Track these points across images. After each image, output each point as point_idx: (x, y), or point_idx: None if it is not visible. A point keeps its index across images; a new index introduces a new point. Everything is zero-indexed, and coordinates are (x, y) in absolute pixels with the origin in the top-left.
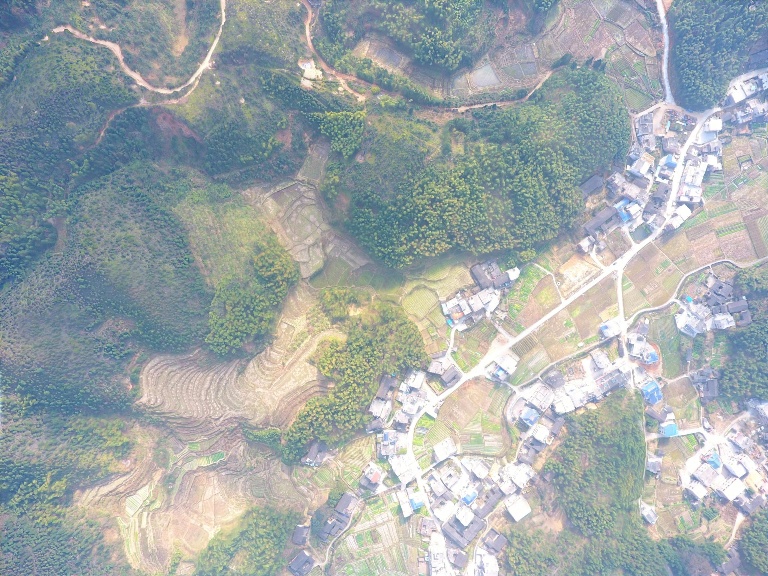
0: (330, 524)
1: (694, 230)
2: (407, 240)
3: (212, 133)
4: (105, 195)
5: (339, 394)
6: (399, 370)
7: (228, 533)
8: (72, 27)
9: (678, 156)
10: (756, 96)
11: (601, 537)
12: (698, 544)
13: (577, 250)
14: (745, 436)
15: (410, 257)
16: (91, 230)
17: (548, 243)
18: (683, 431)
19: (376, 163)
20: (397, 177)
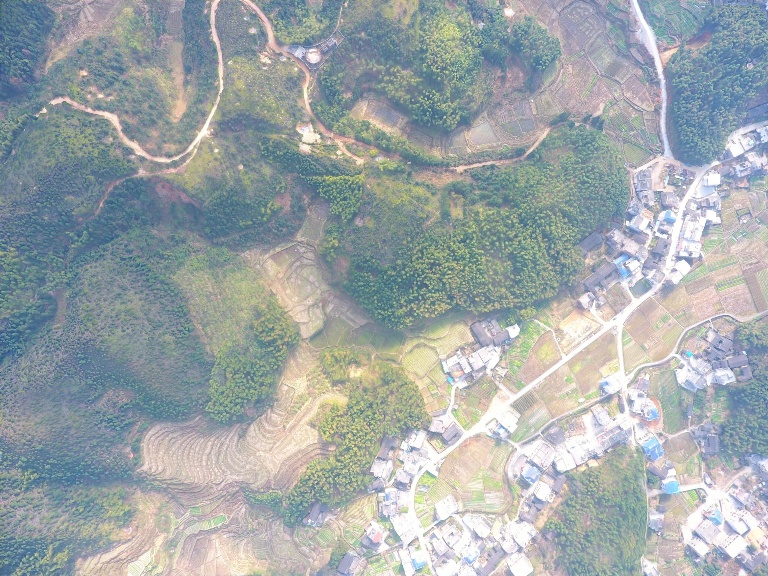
0: None
1: (694, 284)
2: (407, 302)
3: (211, 200)
4: (104, 267)
5: (340, 458)
6: (400, 430)
7: None
8: (70, 98)
9: (677, 210)
10: (754, 149)
11: None
12: None
13: (577, 306)
14: (746, 492)
15: (410, 318)
16: (91, 305)
17: (548, 299)
18: (684, 487)
19: (375, 227)
20: (396, 242)
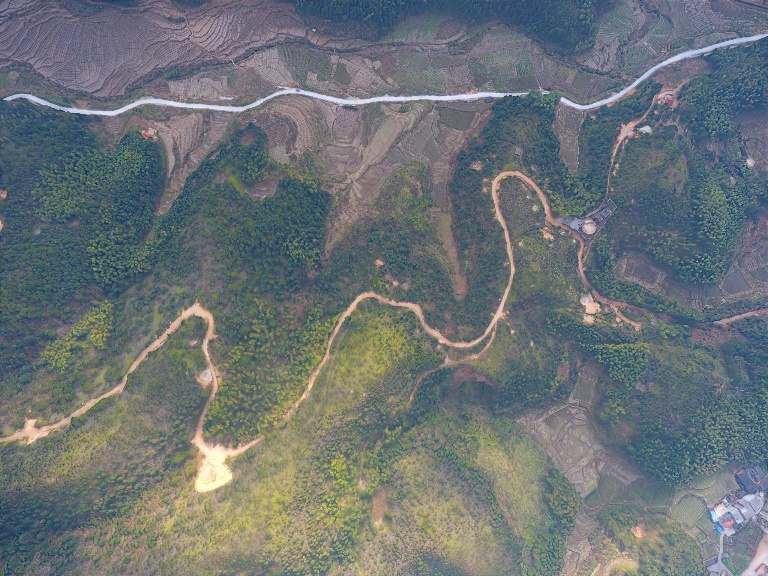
0: None
1: None
2: None
3: (508, 381)
4: (423, 462)
5: None
6: None
7: None
8: (375, 292)
9: None
10: None
11: None
12: None
13: None
14: None
15: (691, 477)
16: (424, 508)
17: None
18: None
19: (664, 395)
20: (689, 410)
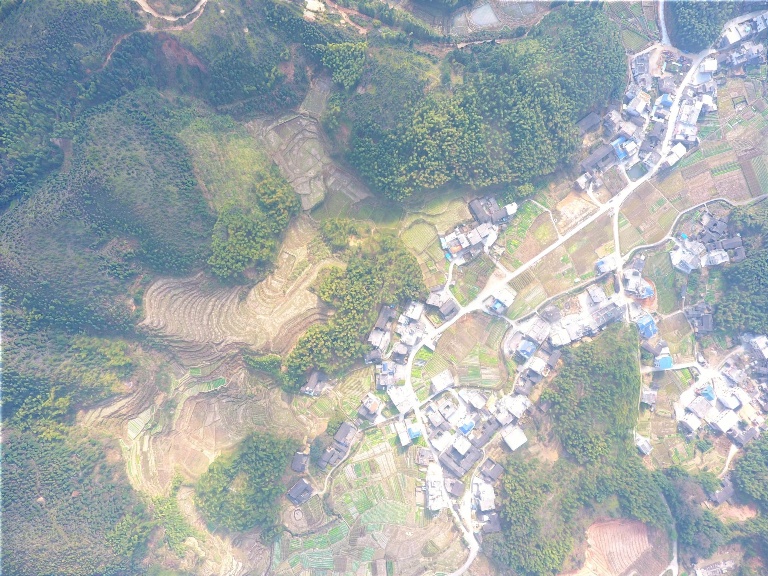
0: (329, 452)
1: (689, 169)
2: (407, 171)
3: (216, 60)
4: (111, 116)
5: (339, 320)
6: (398, 301)
7: (228, 456)
8: None
9: (674, 96)
10: (751, 39)
11: (596, 463)
12: (692, 474)
13: (574, 187)
14: (739, 369)
15: (409, 188)
16: (97, 147)
17: (545, 180)
18: (678, 365)
19: (377, 93)
20: (397, 106)
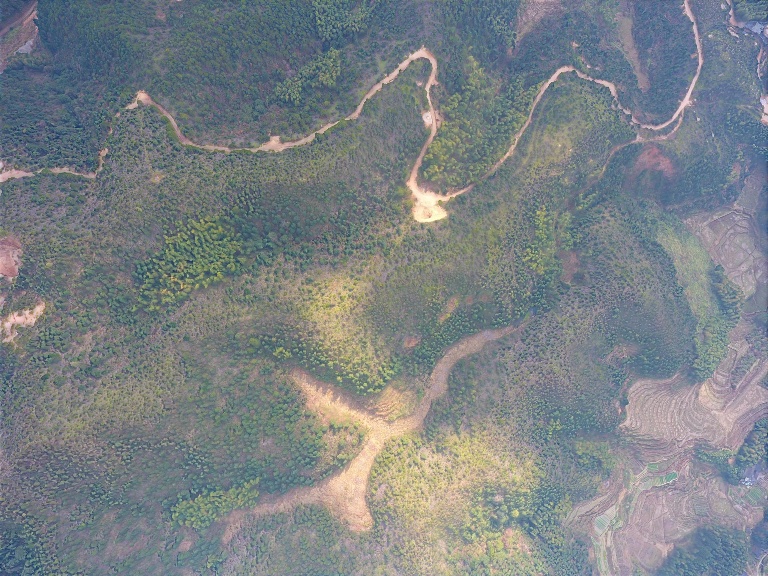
0: None
1: None
2: None
3: (691, 167)
4: (614, 228)
5: None
6: None
7: (696, 551)
8: (574, 67)
9: None
10: None
11: None
12: None
13: None
14: None
15: None
16: (620, 262)
17: None
18: None
19: None
20: None
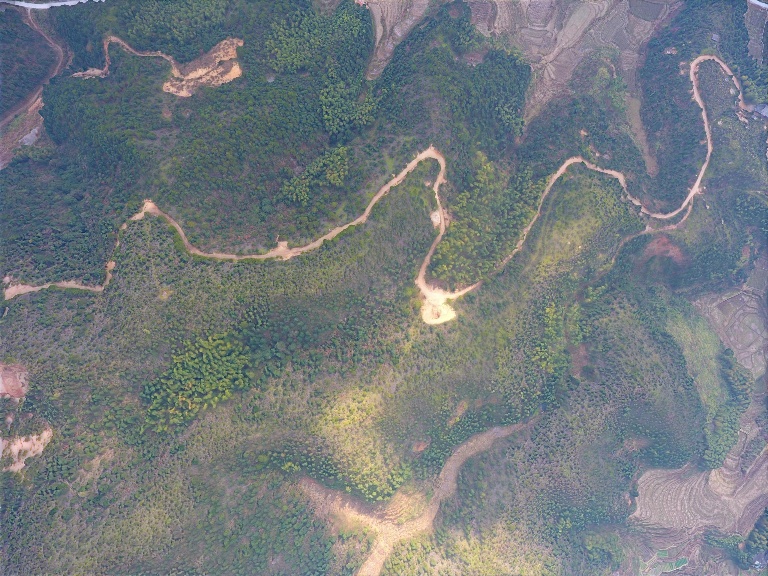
0: None
1: None
2: None
3: (700, 255)
4: (623, 321)
5: None
6: None
7: None
8: (583, 158)
9: None
10: None
11: None
12: None
13: None
14: None
15: None
16: (630, 359)
17: None
18: None
19: None
20: None
